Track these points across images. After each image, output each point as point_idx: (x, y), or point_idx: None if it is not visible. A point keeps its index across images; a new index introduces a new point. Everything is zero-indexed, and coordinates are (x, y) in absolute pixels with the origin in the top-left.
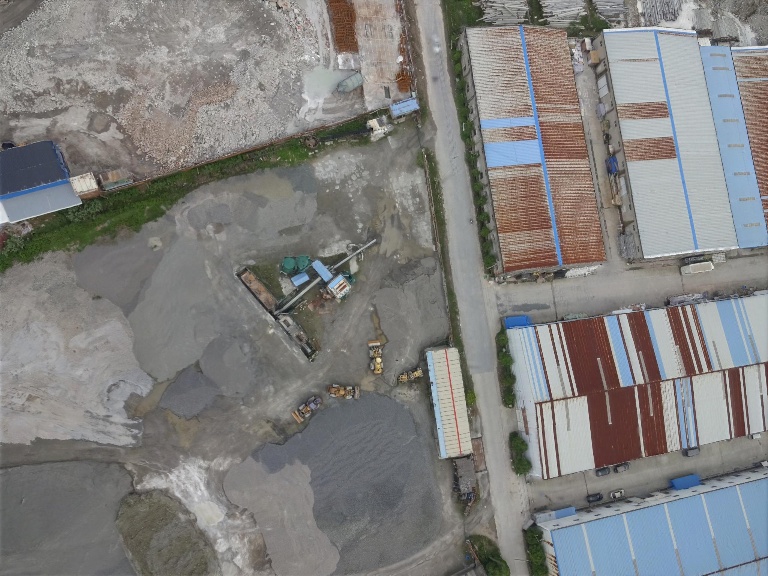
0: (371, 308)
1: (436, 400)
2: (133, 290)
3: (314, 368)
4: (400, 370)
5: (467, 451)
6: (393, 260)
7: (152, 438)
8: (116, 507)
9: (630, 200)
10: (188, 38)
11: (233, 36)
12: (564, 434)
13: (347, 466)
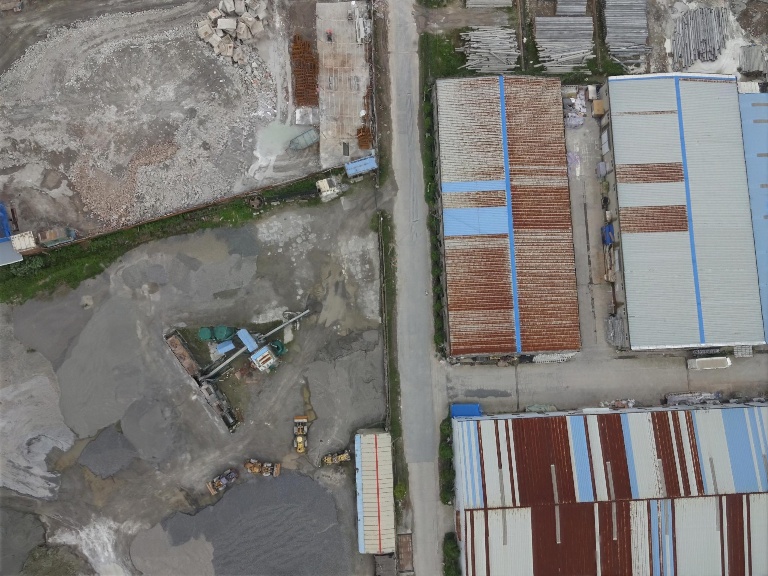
0: (302, 381)
1: (360, 488)
2: (61, 347)
3: (234, 439)
4: (325, 451)
5: (388, 549)
6: (332, 331)
7: (68, 493)
8: (23, 558)
9: (622, 279)
10: (137, 97)
11: (182, 94)
12: (498, 548)
13: (253, 548)
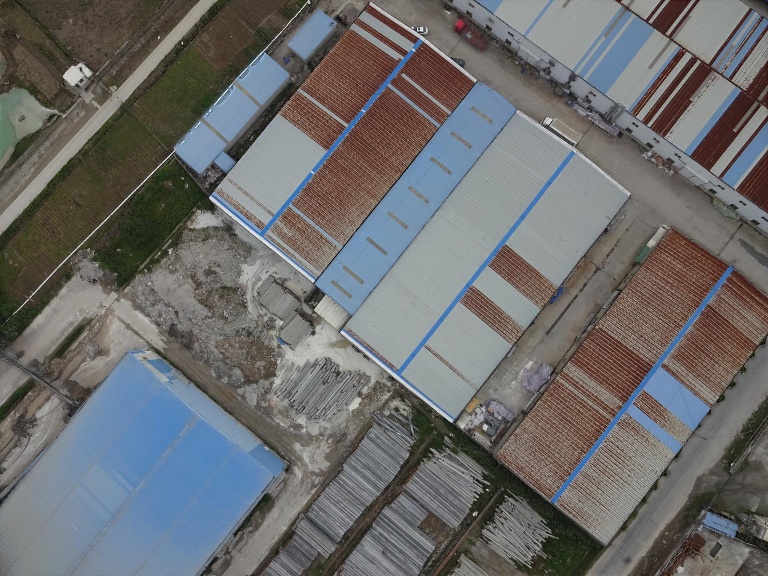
0: None
1: None
2: None
3: None
4: None
5: None
6: None
7: None
8: None
9: None
10: None
11: None
12: None
13: None
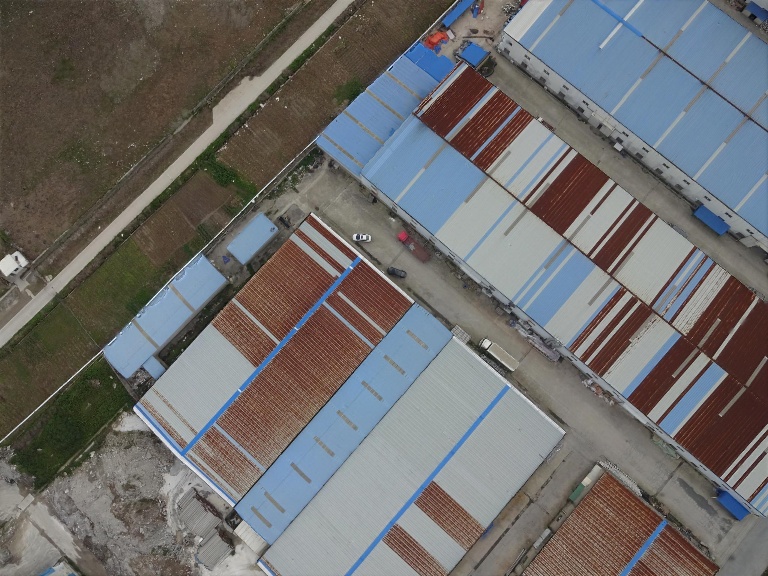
0: None
1: None
2: None
3: None
4: None
5: None
6: None
7: None
8: None
9: None
10: None
11: None
12: None
13: None
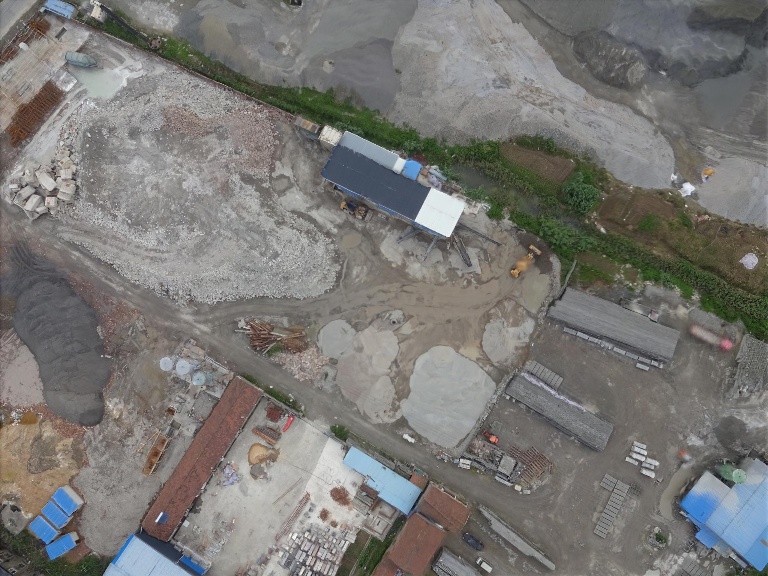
0: None
1: None
2: (372, 48)
3: None
4: None
5: None
6: None
7: None
8: None
9: None
10: (161, 180)
11: (127, 155)
12: None
13: None
